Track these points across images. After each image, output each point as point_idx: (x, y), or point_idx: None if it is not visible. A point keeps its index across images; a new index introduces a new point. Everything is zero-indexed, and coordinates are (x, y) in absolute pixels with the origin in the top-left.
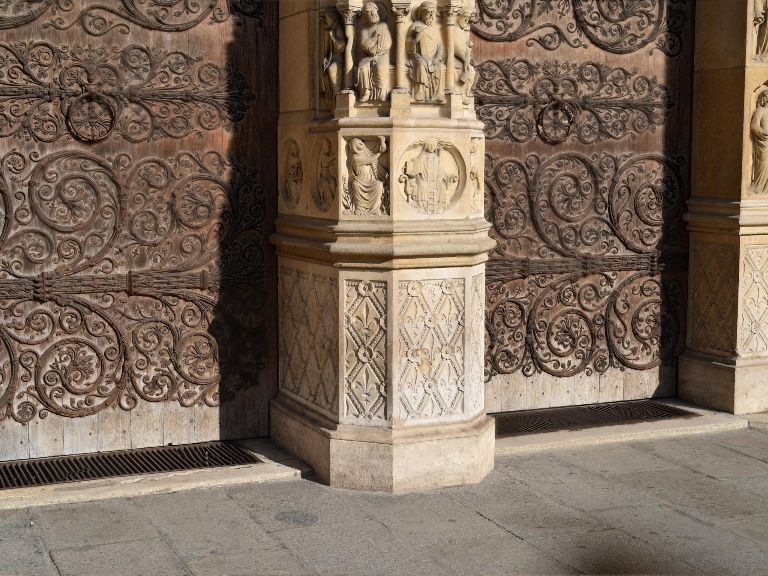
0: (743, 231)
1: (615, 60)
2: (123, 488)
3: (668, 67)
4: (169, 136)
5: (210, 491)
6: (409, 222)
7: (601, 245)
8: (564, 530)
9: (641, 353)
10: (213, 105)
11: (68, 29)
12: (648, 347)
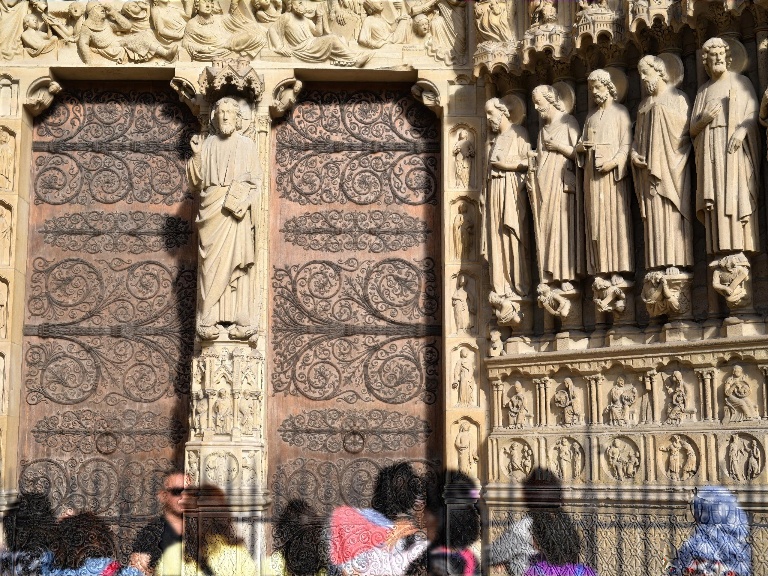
0: (447, 501)
1: (393, 407)
2: None
3: (428, 410)
4: (144, 451)
5: None
6: (209, 489)
7: (386, 510)
8: None
9: (415, 574)
10: (165, 436)
11: (100, 403)
12: (419, 571)
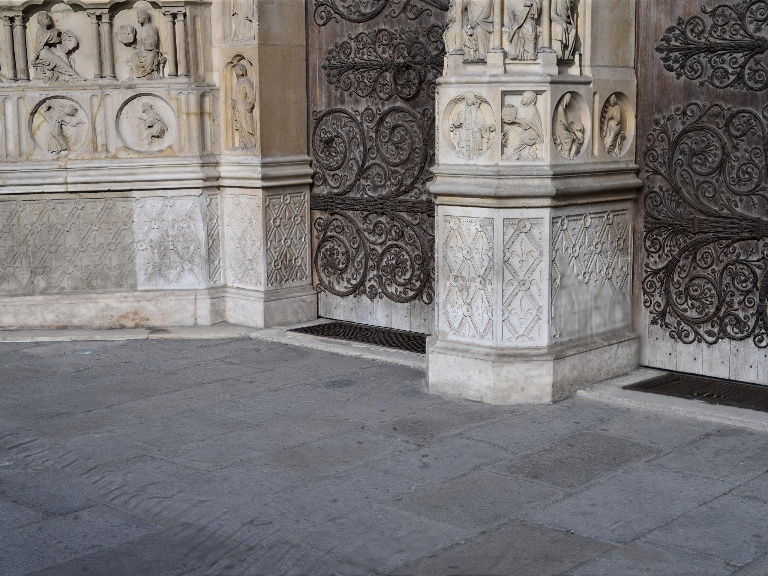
0: None
1: None
2: (344, 348)
3: None
4: None
5: (374, 362)
6: (451, 165)
7: None
8: (393, 434)
9: None
10: None
11: (398, 17)
12: None
